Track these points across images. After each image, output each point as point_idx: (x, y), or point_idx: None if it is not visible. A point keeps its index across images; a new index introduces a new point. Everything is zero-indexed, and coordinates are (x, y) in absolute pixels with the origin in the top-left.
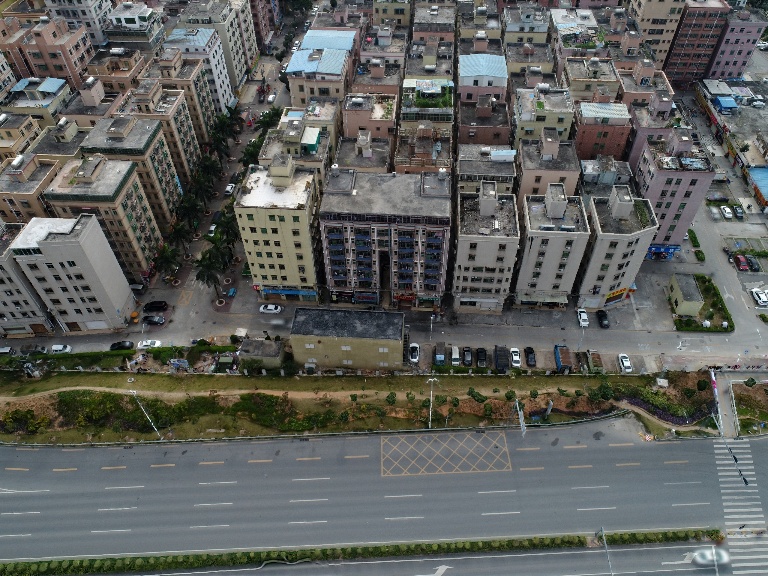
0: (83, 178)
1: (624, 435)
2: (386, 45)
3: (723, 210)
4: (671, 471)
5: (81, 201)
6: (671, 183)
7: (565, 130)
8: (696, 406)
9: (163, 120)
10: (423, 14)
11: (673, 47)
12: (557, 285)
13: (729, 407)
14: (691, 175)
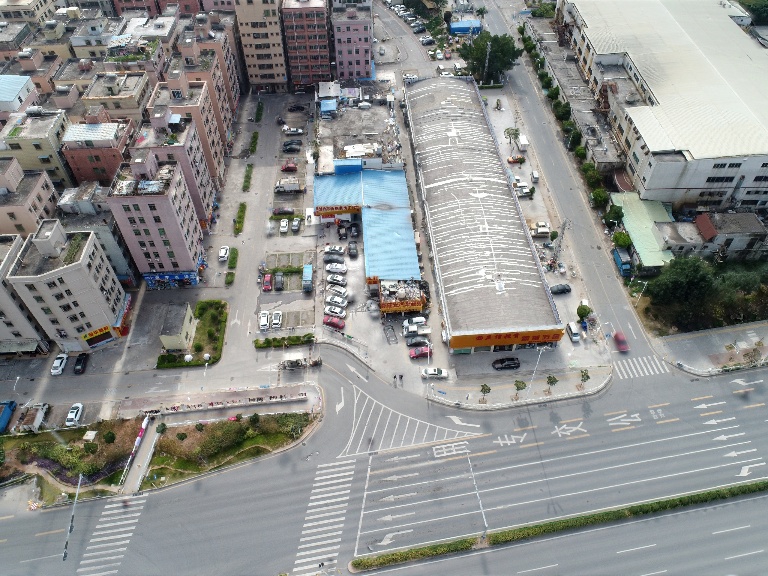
0: None
1: (9, 506)
2: None
3: (280, 224)
4: (37, 545)
5: None
6: (130, 209)
7: (51, 157)
8: (110, 460)
9: None
10: None
11: (287, 50)
12: (16, 333)
13: None
14: (144, 200)
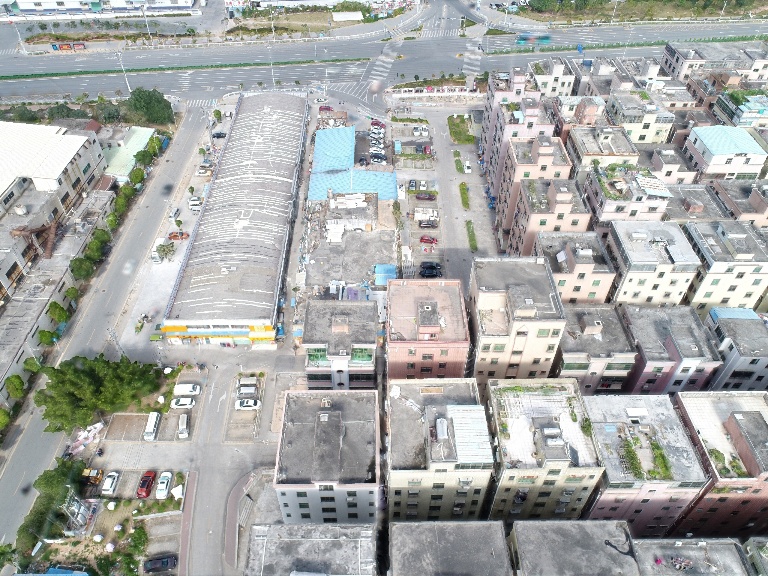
0: None
1: None
2: None
3: None
4: None
5: None
6: None
7: None
8: None
9: None
10: None
11: None
12: None
13: (468, 83)
14: None
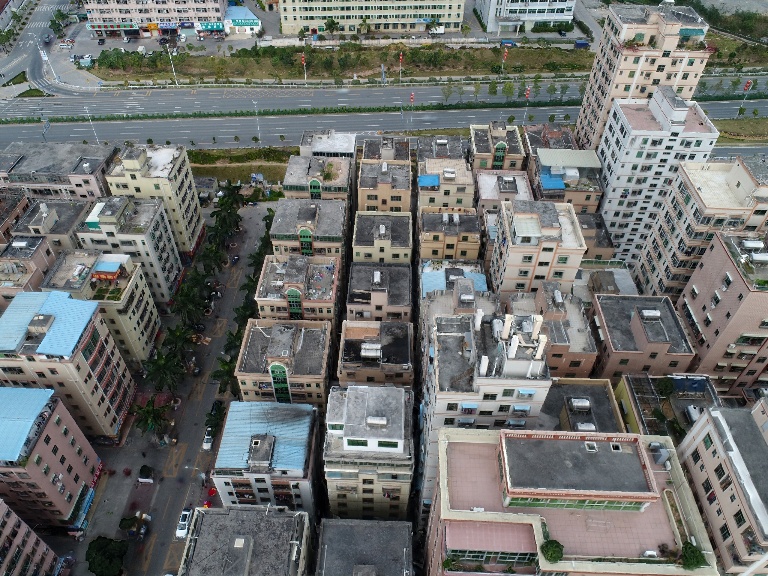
0: None
1: None
2: None
3: None
4: None
5: None
6: None
7: None
8: None
9: None
10: None
11: None
12: None
13: None
14: None
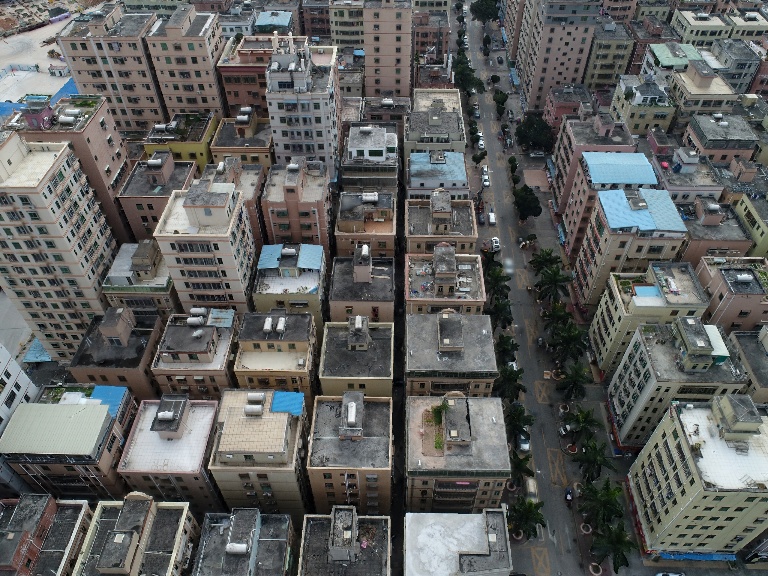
0: (460, 441)
1: None
2: (689, 173)
3: None
4: None
5: (461, 476)
6: None
7: None
8: None
9: (474, 305)
10: (709, 125)
11: None
12: None
13: None
14: None
